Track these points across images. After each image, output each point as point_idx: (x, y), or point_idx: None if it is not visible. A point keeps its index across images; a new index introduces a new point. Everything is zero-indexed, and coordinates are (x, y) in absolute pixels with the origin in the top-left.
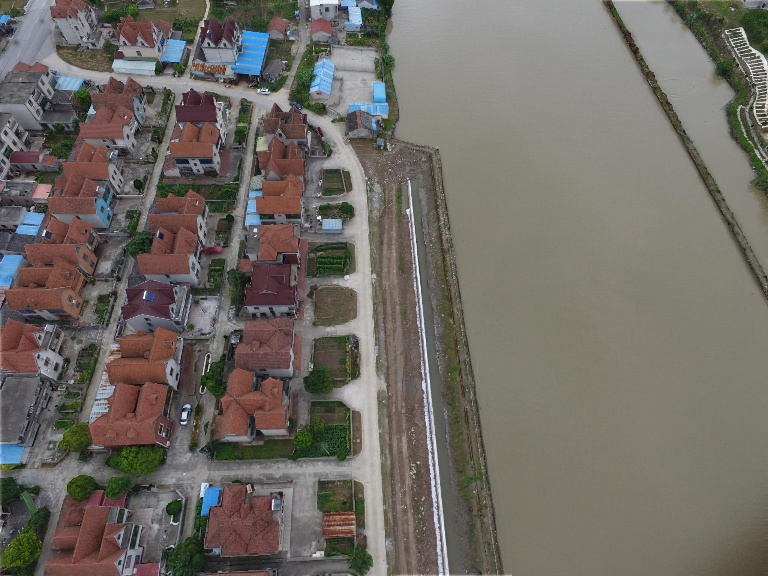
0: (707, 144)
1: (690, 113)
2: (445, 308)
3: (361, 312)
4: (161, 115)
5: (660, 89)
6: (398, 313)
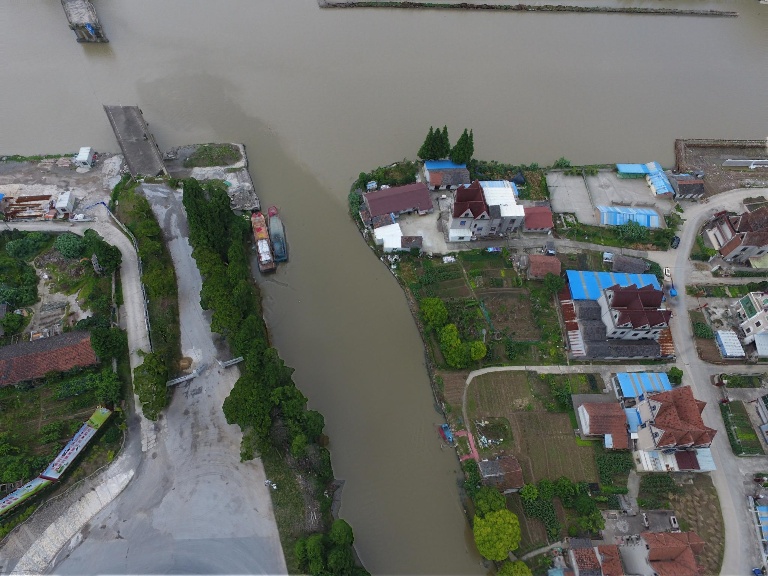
0: (593, 2)
1: (558, 1)
2: None
3: None
4: None
5: (539, 6)
6: None
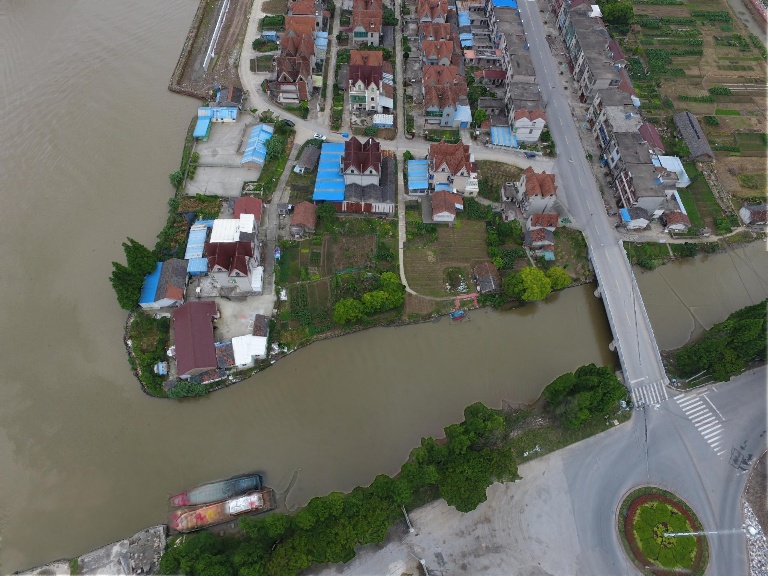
0: None
1: None
2: (210, 8)
3: (260, 3)
4: (408, 108)
5: None
6: (239, 6)
